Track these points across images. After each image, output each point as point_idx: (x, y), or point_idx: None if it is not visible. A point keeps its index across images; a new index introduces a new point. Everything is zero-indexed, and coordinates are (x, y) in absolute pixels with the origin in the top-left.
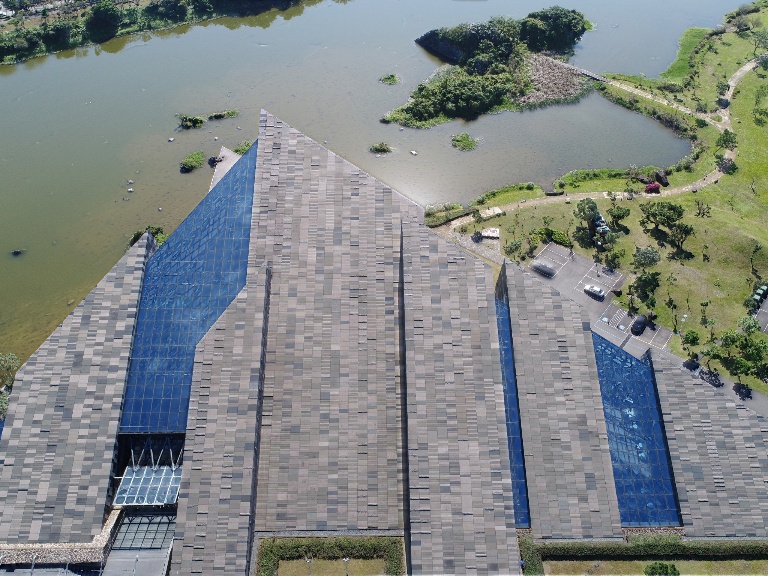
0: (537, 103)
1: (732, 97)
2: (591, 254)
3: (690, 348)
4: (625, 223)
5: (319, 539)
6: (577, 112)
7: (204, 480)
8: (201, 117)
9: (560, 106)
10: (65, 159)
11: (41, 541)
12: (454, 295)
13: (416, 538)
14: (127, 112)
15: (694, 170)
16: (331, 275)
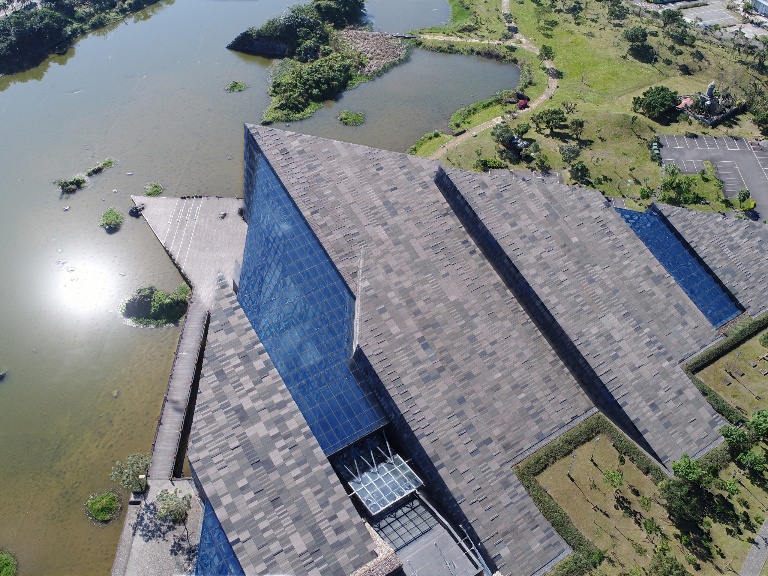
0: (380, 69)
1: (515, 23)
2: (525, 167)
3: (643, 203)
4: (527, 136)
5: (548, 446)
6: (416, 67)
7: (447, 446)
8: (78, 177)
9: (399, 67)
10: None
11: None
12: (522, 215)
13: (622, 401)
14: None
15: (536, 83)
16: (408, 242)
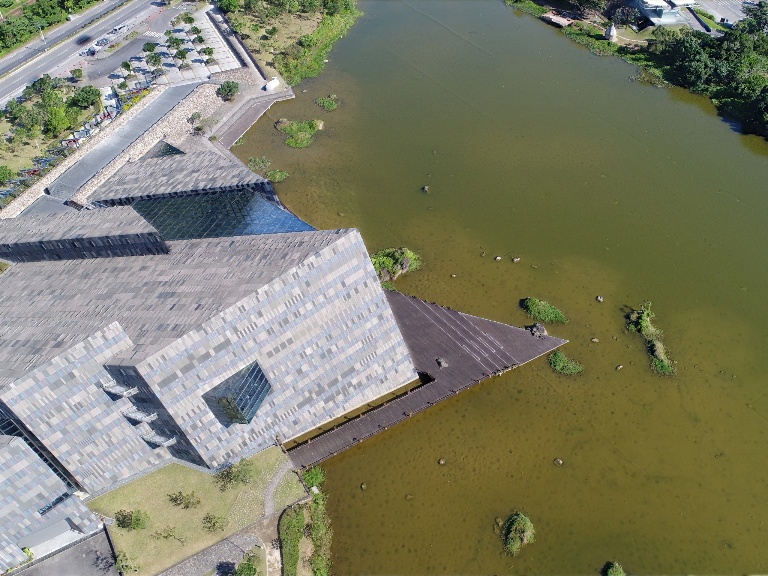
0: None
1: None
2: None
3: None
4: None
5: None
6: None
7: None
8: (654, 331)
9: None
10: (577, 219)
11: None
12: (7, 357)
13: None
14: (679, 268)
15: None
16: (136, 292)
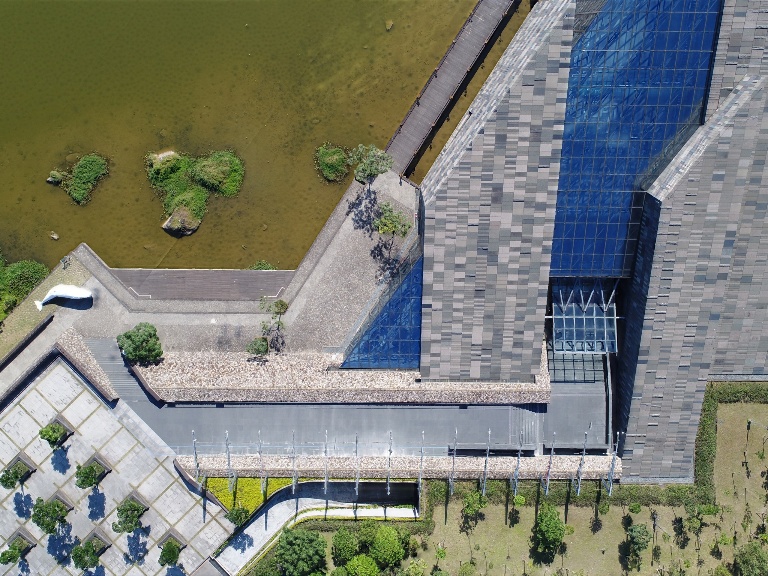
0: None
1: None
2: None
3: None
4: None
5: (756, 384)
6: None
7: (664, 348)
8: None
9: None
10: None
11: (483, 378)
12: None
13: None
14: None
15: None
16: None
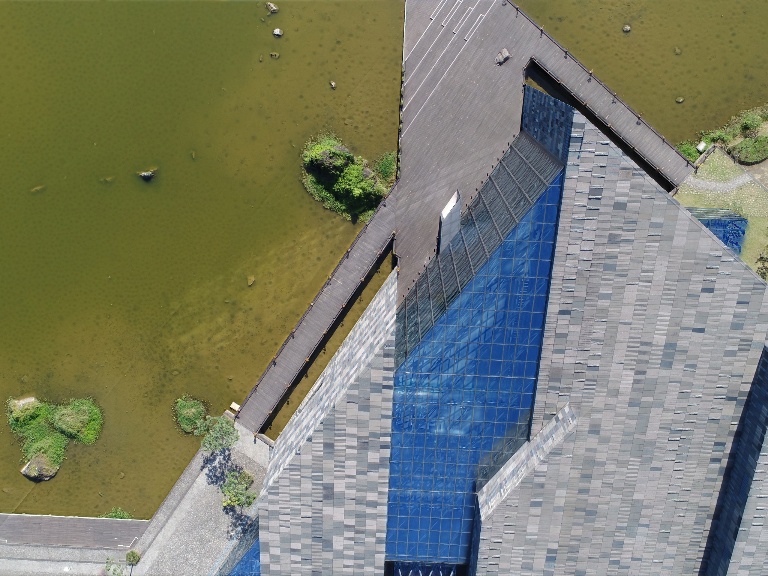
0: None
1: None
2: None
3: None
4: None
5: None
6: None
7: None
8: None
9: None
10: None
11: None
12: None
13: None
14: None
15: None
16: (649, 410)
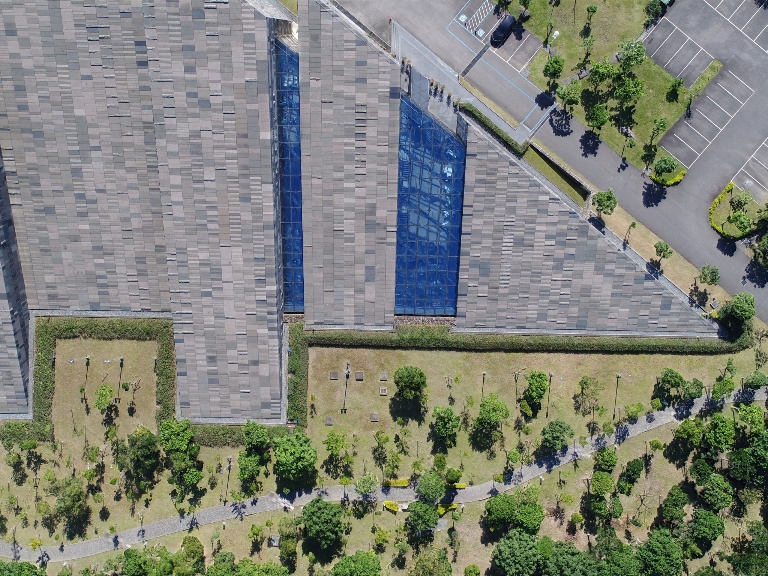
0: None
1: None
2: None
3: None
4: None
5: (93, 320)
6: None
7: None
8: None
9: None
10: None
11: None
12: (214, 61)
13: (179, 337)
14: None
15: None
16: (57, 3)
